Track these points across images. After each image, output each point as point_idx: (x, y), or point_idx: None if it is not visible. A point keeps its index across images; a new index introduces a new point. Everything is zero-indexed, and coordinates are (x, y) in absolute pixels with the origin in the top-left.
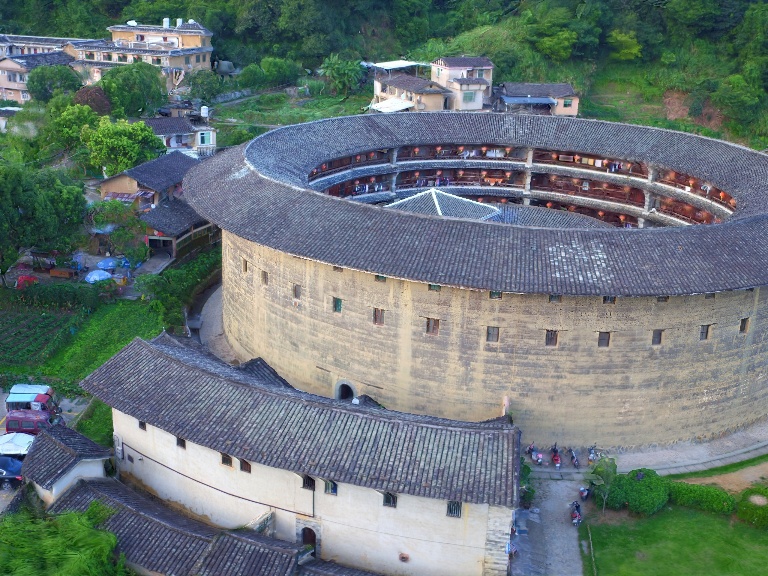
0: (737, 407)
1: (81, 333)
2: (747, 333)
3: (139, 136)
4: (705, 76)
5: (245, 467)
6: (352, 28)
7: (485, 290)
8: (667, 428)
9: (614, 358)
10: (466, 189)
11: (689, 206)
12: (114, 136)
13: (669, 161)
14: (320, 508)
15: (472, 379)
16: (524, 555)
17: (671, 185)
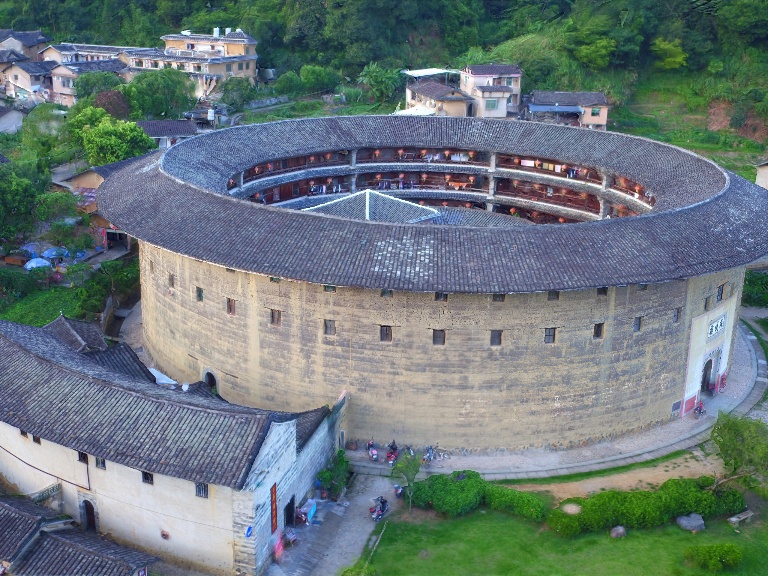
0: (599, 416)
1: (1, 315)
2: (603, 339)
3: (128, 136)
4: (754, 86)
5: (37, 439)
6: (399, 37)
7: (303, 281)
8: (515, 432)
9: (450, 357)
10: (430, 193)
11: (635, 213)
12: (104, 136)
13: (619, 167)
14: (94, 481)
15: (313, 372)
16: (304, 544)
17: (623, 192)
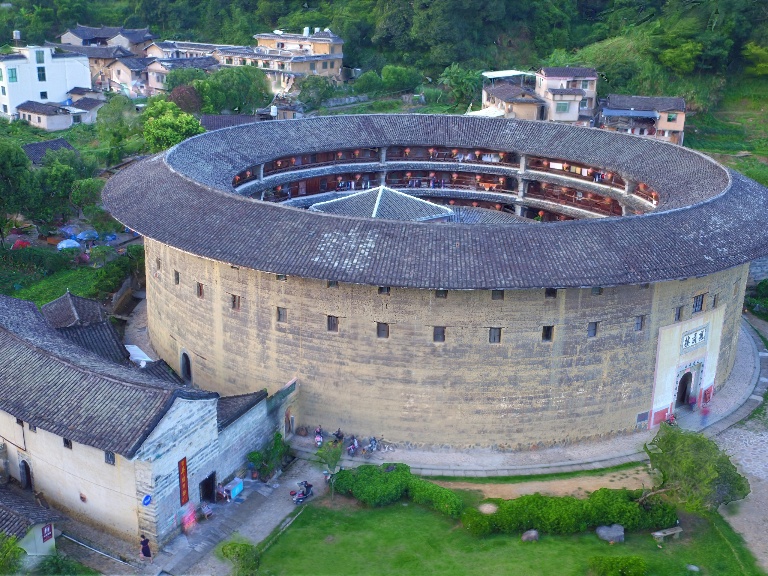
0: (550, 420)
1: (24, 290)
2: (553, 342)
3: (183, 128)
4: None
5: None
6: (486, 38)
7: (247, 268)
8: (460, 430)
9: (394, 350)
10: (460, 192)
11: None
12: (161, 128)
13: (640, 172)
14: (29, 443)
15: (268, 357)
16: (218, 519)
17: (644, 197)
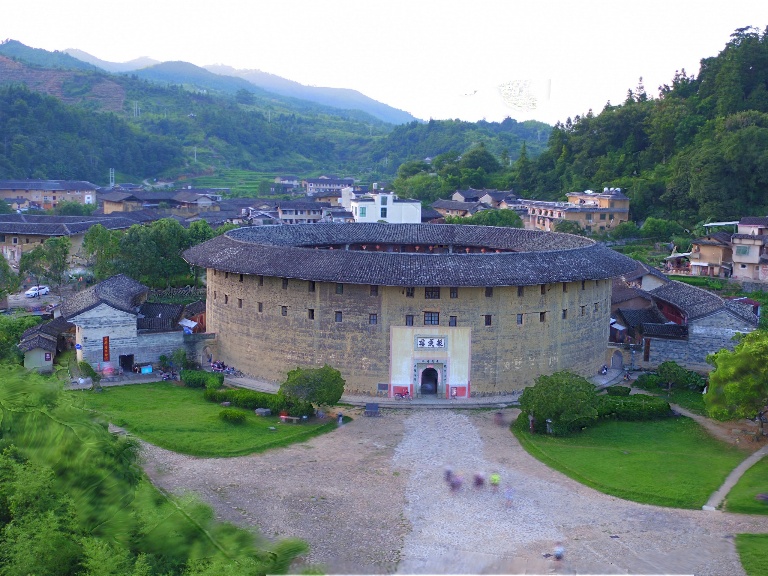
0: None
1: None
2: (314, 320)
3: None
4: None
5: None
6: (765, 199)
7: None
8: (270, 369)
9: None
10: None
11: None
12: None
13: None
14: None
15: None
16: None
17: None
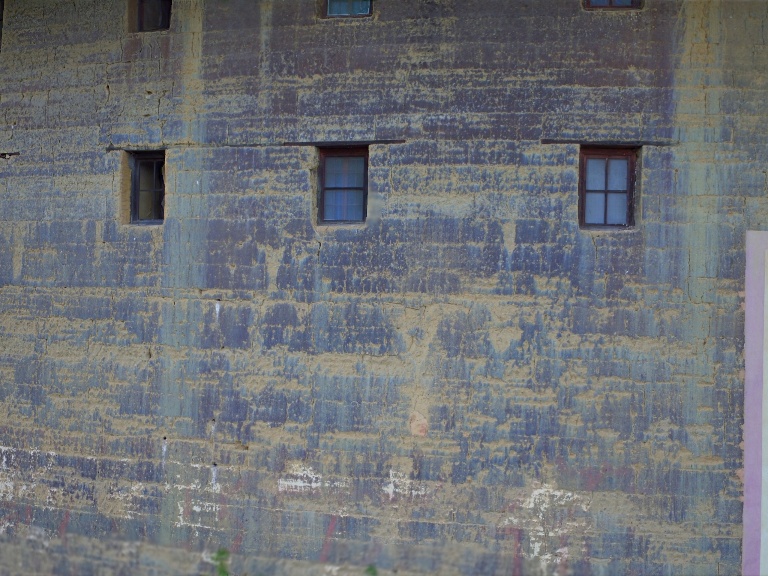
0: None
1: None
2: (165, 223)
3: None
4: None
5: None
6: None
7: None
8: None
9: None
10: None
11: None
12: None
13: None
14: None
15: None
16: None
17: None
